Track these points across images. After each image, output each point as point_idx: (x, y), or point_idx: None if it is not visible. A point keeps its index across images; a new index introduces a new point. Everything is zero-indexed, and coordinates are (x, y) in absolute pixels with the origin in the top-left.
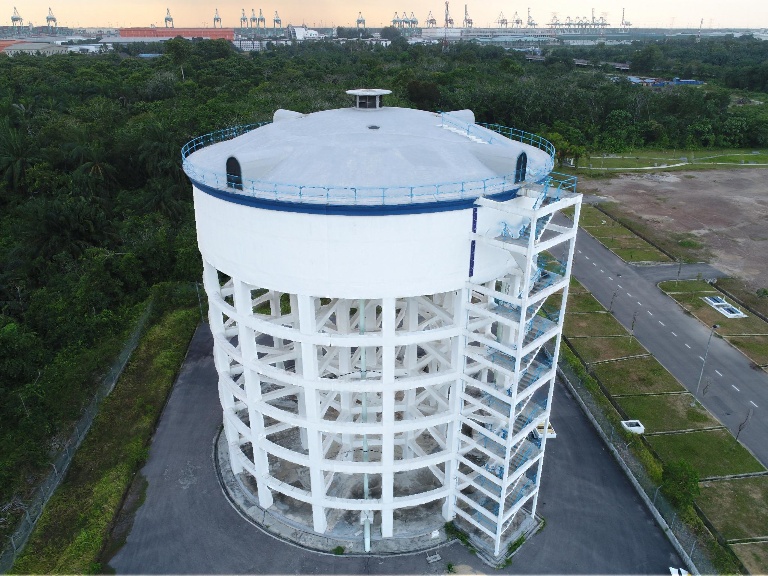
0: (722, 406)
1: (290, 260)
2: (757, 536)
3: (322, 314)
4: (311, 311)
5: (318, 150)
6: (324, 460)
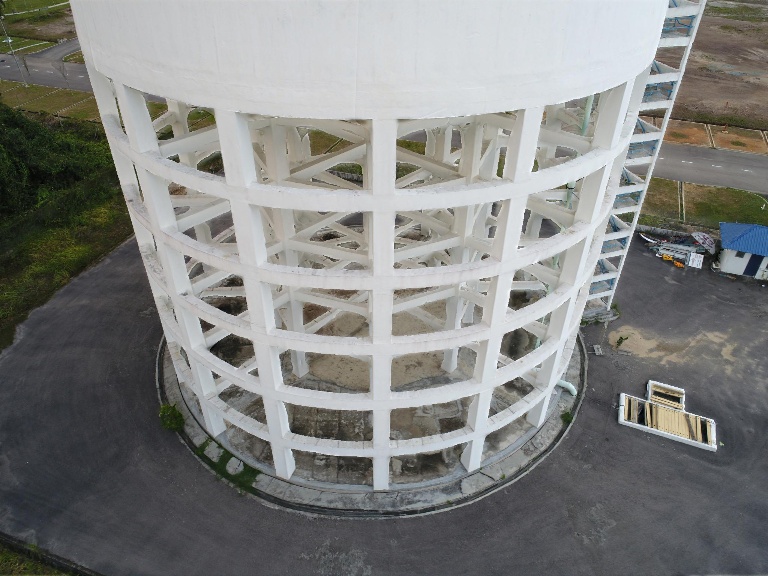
0: None
1: (637, 18)
2: None
3: (551, 128)
4: None
5: None
6: None
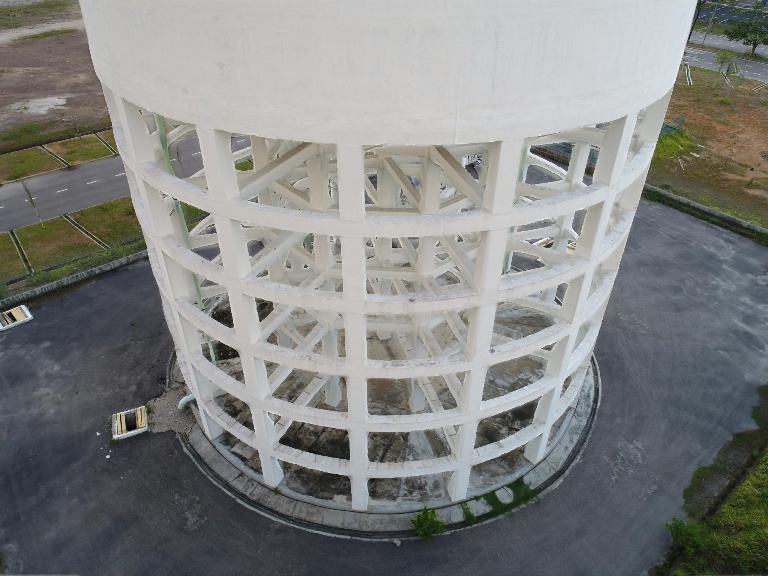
0: None
1: None
2: None
3: None
4: None
5: None
6: None
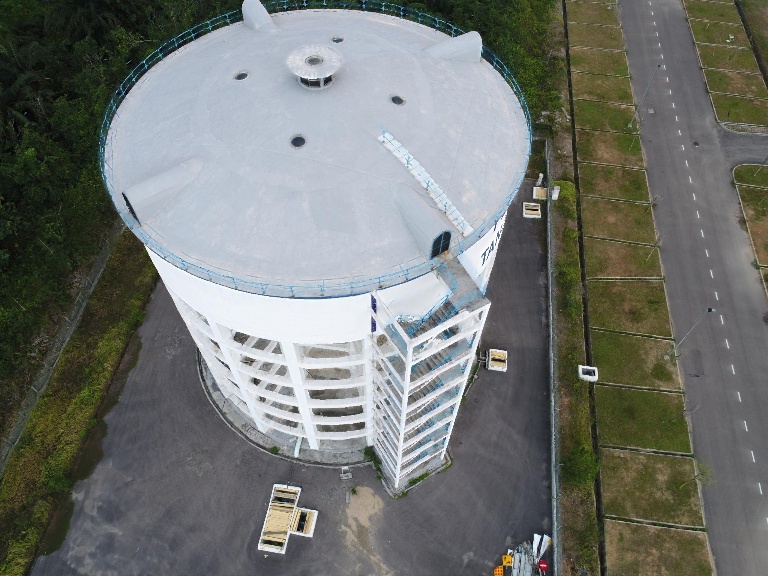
0: (697, 365)
1: (193, 294)
2: (635, 517)
3: None
4: (221, 329)
5: (224, 179)
6: (256, 402)
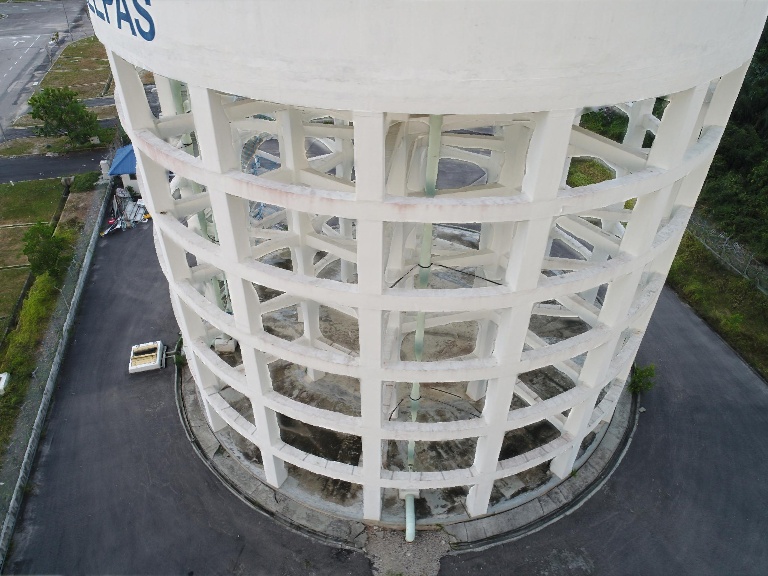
0: None
1: None
2: None
3: None
4: None
5: None
6: None
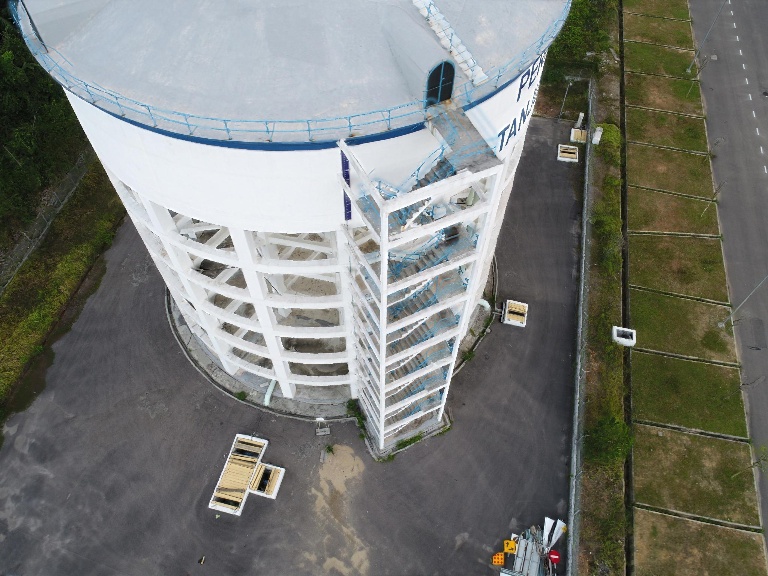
0: (758, 336)
1: (117, 156)
2: (674, 509)
3: None
4: (158, 213)
5: None
6: (217, 330)
